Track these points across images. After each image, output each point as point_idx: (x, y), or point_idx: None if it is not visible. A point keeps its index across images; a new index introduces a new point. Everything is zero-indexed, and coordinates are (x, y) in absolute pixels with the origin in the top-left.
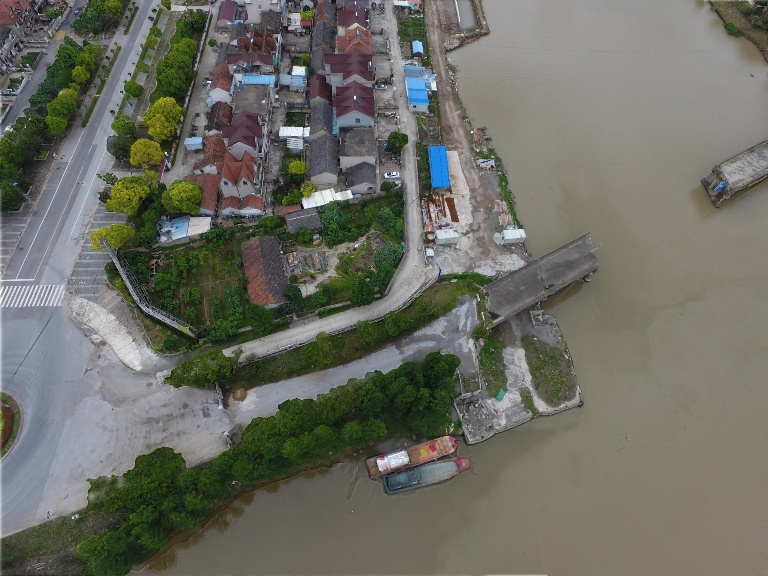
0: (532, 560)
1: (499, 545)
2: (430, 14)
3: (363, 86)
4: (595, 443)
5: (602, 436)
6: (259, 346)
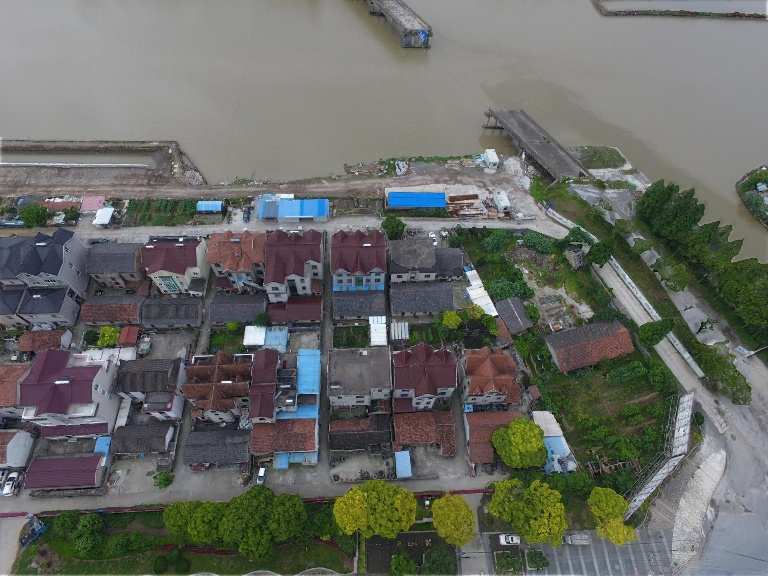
0: (720, 187)
1: (719, 202)
2: (121, 193)
3: (334, 242)
4: (638, 147)
5: (632, 143)
6: (659, 344)
